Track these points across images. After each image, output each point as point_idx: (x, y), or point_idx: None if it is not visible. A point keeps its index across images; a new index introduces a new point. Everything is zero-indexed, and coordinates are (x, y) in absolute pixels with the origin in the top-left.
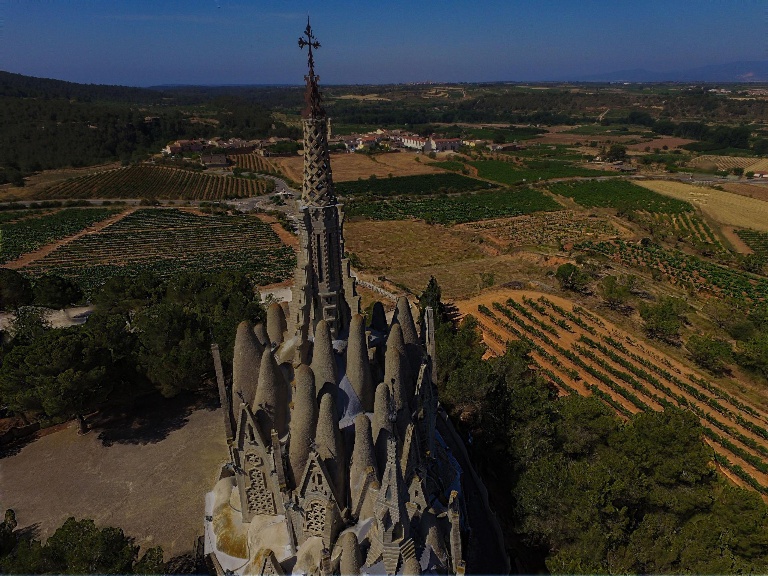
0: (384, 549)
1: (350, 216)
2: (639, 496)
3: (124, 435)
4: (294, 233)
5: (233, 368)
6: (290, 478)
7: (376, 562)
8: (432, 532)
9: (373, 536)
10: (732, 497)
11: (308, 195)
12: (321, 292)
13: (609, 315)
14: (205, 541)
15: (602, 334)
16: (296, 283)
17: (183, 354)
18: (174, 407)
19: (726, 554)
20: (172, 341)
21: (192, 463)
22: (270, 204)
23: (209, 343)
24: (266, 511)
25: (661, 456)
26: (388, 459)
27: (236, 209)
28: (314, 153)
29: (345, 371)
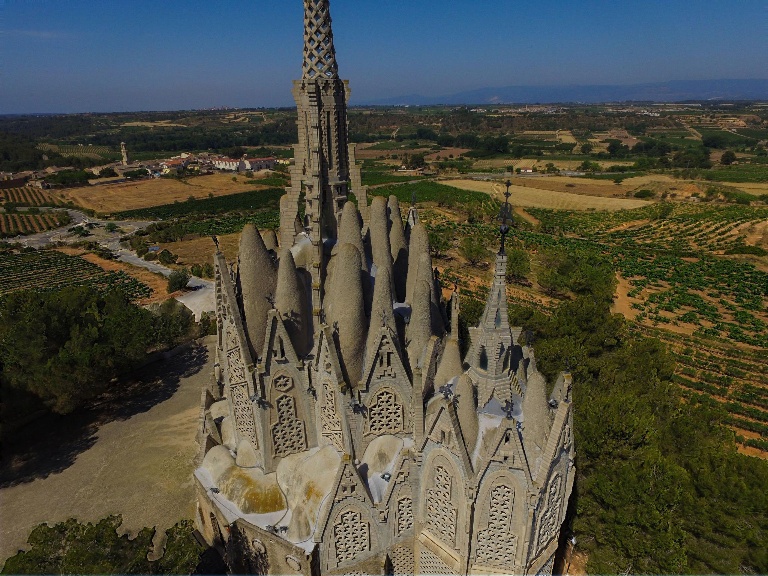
0: (495, 383)
1: (183, 234)
2: (584, 364)
3: (5, 478)
4: (117, 260)
5: (241, 282)
6: (344, 378)
7: (488, 401)
8: (521, 365)
9: (479, 377)
10: (642, 346)
11: (315, 66)
12: (331, 181)
13: (473, 272)
14: (222, 512)
15: (476, 285)
16: (293, 181)
17: (77, 354)
18: (68, 430)
19: (657, 383)
20: (49, 348)
21: (128, 475)
22: (71, 237)
23: (106, 340)
24: (294, 449)
25: (586, 333)
26: (497, 279)
27: (23, 247)
28: (320, 17)
29: (372, 260)
